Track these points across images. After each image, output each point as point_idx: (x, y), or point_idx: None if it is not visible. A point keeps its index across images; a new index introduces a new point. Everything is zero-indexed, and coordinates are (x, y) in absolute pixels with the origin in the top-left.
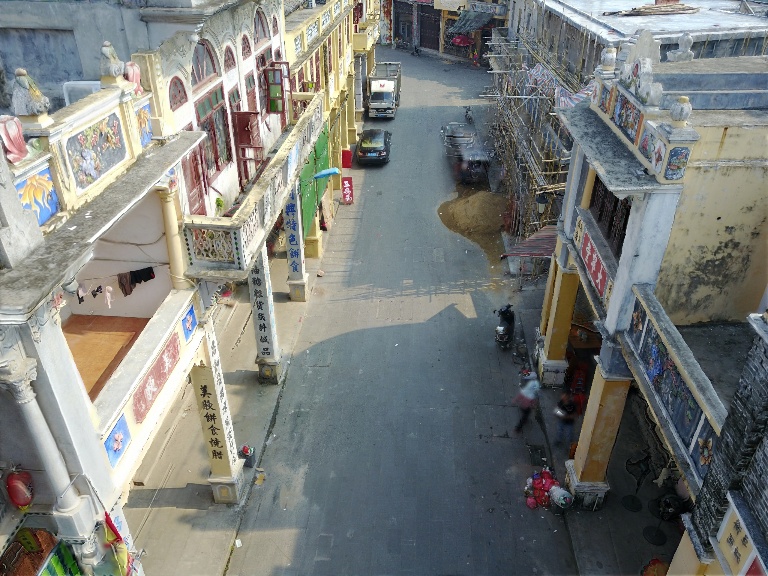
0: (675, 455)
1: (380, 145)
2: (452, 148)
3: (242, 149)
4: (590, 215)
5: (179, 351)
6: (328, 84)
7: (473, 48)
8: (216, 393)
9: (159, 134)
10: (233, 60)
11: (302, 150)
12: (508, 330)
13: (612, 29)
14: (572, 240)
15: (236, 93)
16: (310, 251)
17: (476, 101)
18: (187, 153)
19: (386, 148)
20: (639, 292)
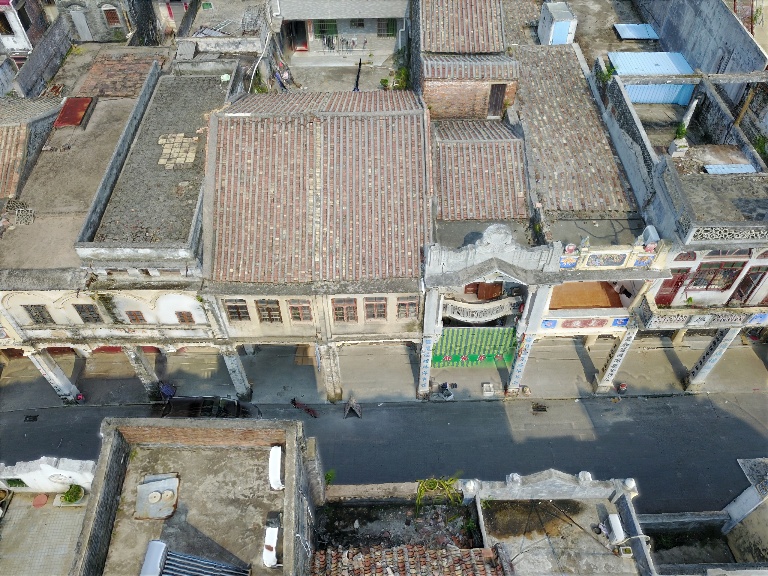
0: None
1: None
2: None
3: (752, 290)
4: None
5: (604, 325)
6: None
7: None
8: (616, 352)
9: (650, 266)
10: None
11: None
12: None
13: None
14: None
15: (766, 268)
16: None
17: None
18: None
19: None
20: None
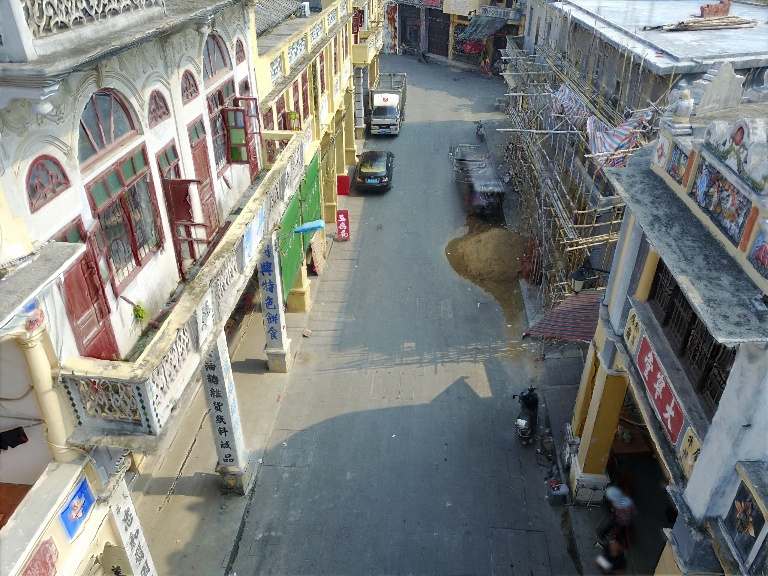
0: None
1: (381, 170)
2: (462, 173)
3: None
4: (650, 312)
5: (56, 561)
6: (318, 109)
7: (484, 55)
8: (134, 575)
9: None
10: (166, 108)
11: (272, 212)
12: (531, 422)
13: (660, 50)
14: (622, 337)
15: (172, 151)
16: (296, 304)
17: (488, 115)
18: (38, 292)
19: (388, 173)
20: (750, 478)
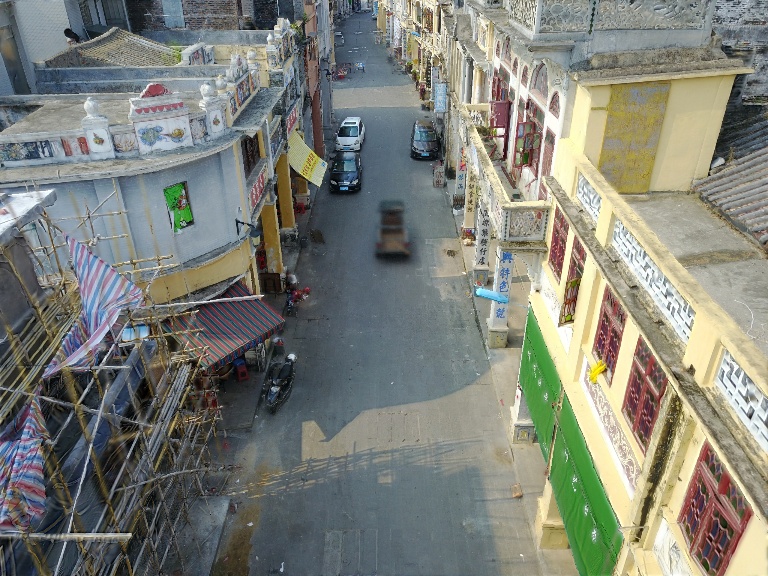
0: (283, 146)
1: None
2: None
3: None
4: None
5: None
6: None
7: None
8: None
9: None
10: None
11: None
12: None
13: None
14: None
15: None
16: None
17: None
18: None
19: None
20: None
